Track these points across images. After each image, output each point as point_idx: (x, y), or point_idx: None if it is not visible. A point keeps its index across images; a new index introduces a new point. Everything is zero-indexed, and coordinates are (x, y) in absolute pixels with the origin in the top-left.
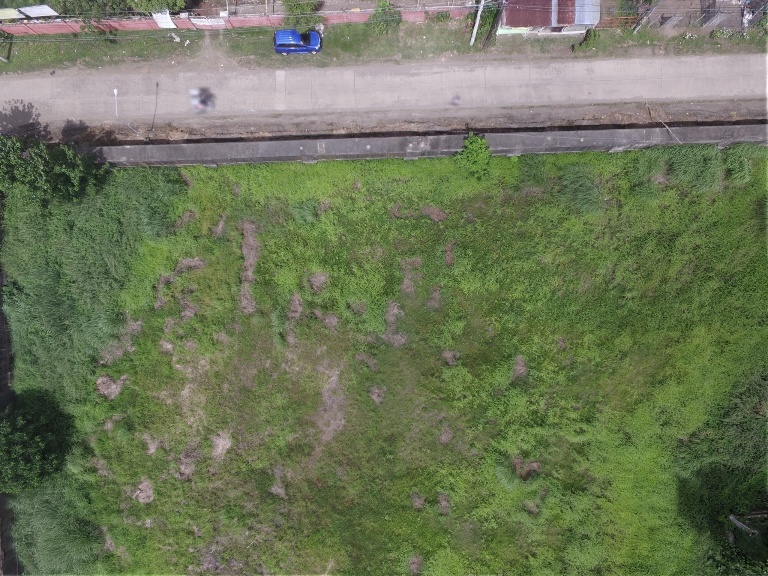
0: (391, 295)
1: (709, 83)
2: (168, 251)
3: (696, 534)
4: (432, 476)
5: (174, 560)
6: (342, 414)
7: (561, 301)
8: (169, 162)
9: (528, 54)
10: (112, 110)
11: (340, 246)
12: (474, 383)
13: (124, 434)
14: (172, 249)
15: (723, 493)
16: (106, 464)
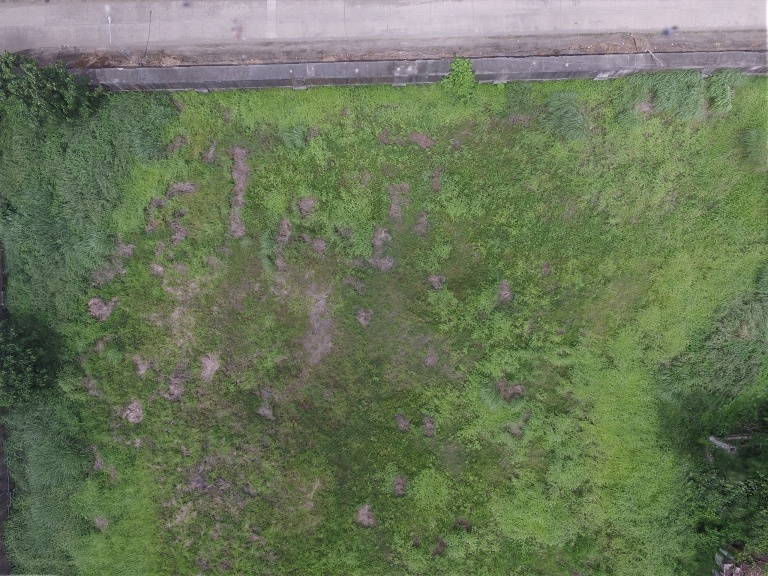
0: (378, 220)
1: (694, 14)
2: (159, 175)
3: (677, 456)
4: (417, 398)
5: (163, 479)
6: (329, 337)
7: (546, 227)
8: (161, 85)
9: None
10: (106, 37)
11: (329, 171)
12: (459, 307)
13: (114, 353)
14: (163, 173)
15: (704, 415)
16: (97, 384)
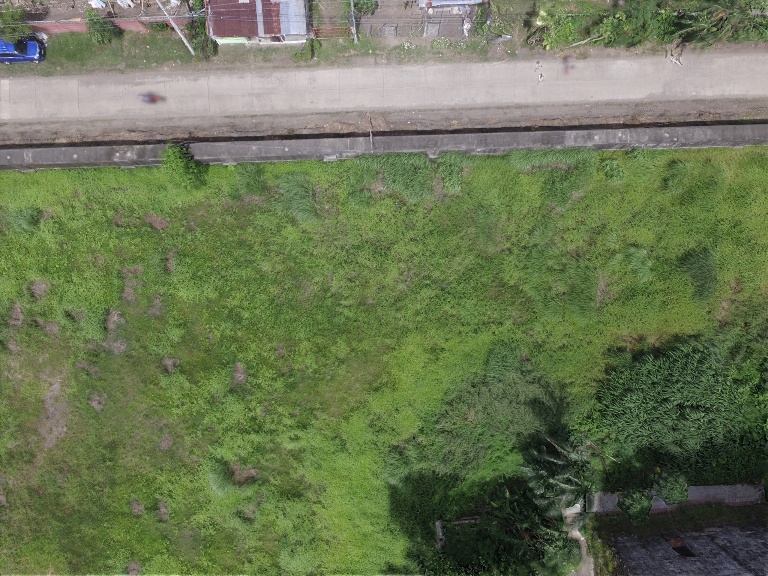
0: (111, 303)
1: (430, 92)
2: None
3: (407, 540)
4: (151, 483)
5: None
6: (64, 421)
7: (280, 309)
8: None
9: (250, 63)
10: None
11: (61, 254)
12: (193, 390)
13: None
14: None
15: (433, 499)
16: None
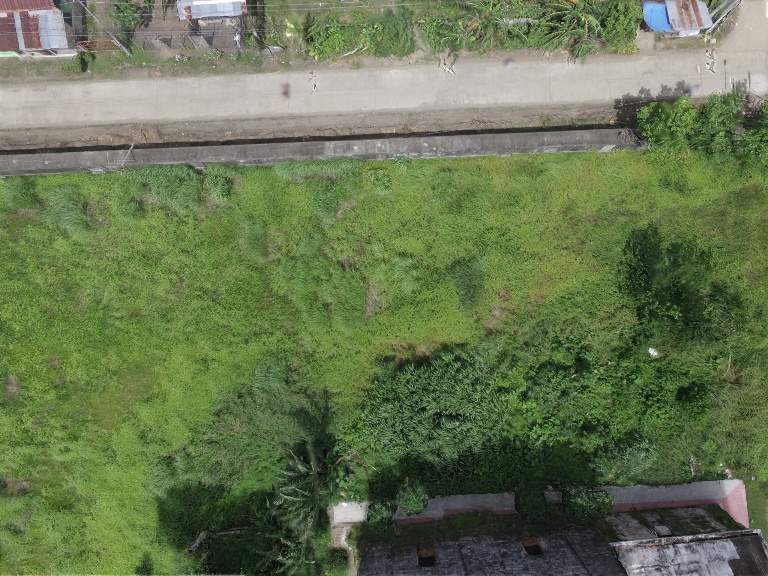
0: None
1: (204, 104)
2: None
3: (176, 551)
4: None
5: None
6: None
7: (52, 321)
8: None
9: (24, 77)
10: None
11: None
12: None
13: None
14: None
15: (200, 510)
16: None
